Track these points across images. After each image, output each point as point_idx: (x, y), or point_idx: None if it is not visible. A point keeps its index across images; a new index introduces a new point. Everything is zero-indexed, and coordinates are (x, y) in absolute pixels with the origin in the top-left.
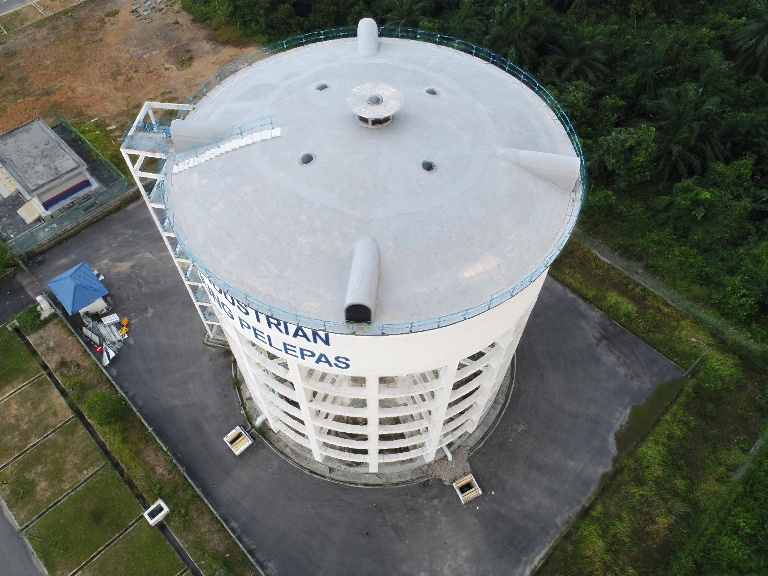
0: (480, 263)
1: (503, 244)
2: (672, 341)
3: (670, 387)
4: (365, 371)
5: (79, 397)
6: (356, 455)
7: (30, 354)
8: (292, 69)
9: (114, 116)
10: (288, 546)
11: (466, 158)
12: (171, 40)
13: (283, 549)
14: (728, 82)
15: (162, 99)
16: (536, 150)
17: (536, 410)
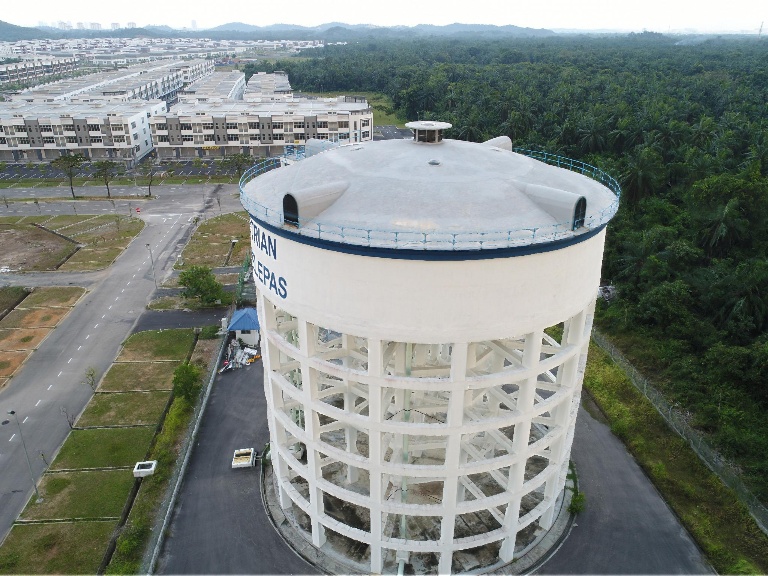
0: (418, 222)
1: (452, 220)
2: None
3: None
4: (296, 306)
5: None
6: (304, 500)
7: (189, 348)
8: None
9: None
10: (194, 553)
11: (473, 171)
12: None
13: (189, 553)
14: None
15: None
16: None
17: None
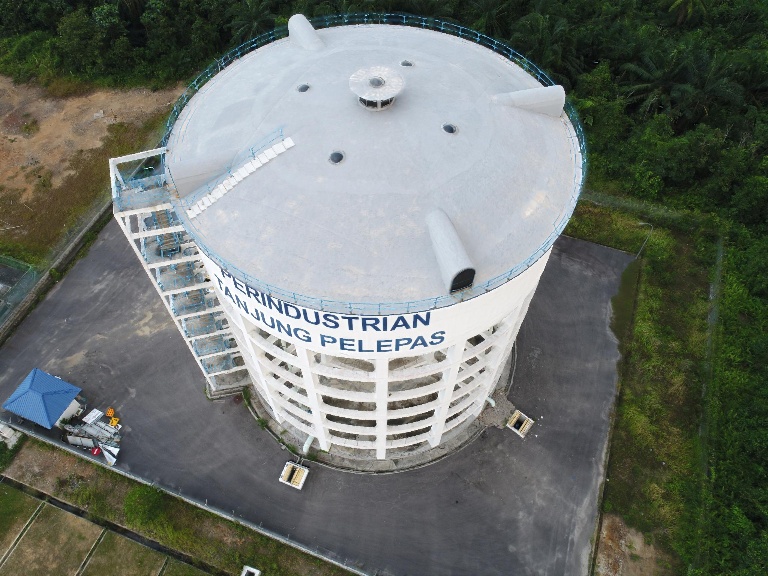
0: (532, 200)
1: (540, 177)
2: (614, 234)
3: (631, 272)
4: (457, 338)
5: (100, 509)
6: (421, 435)
7: (16, 490)
8: (254, 82)
9: None
10: (393, 548)
11: (474, 113)
12: (0, 109)
13: (389, 553)
14: (557, 5)
15: (25, 173)
16: (516, 90)
17: (540, 333)
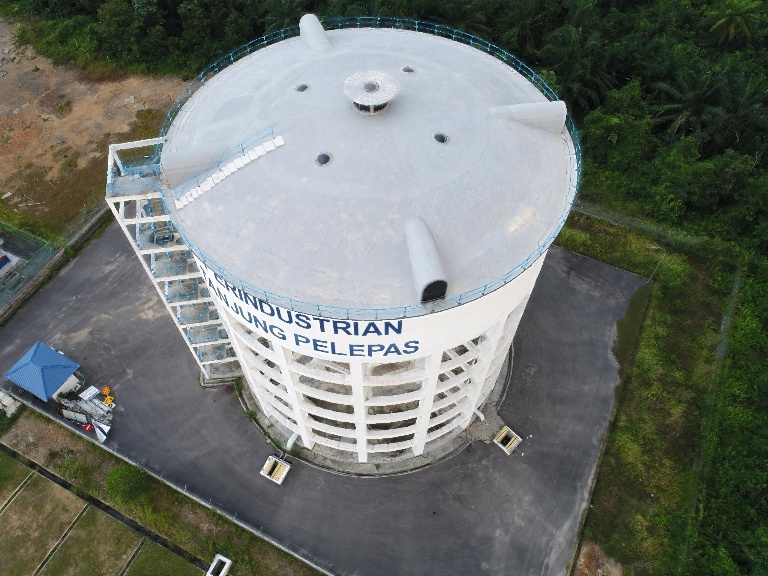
0: (518, 216)
1: (530, 193)
2: (627, 256)
3: (640, 296)
4: (432, 349)
5: (86, 483)
6: (403, 442)
7: (10, 457)
8: (257, 78)
9: (5, 182)
10: (364, 552)
11: (469, 123)
12: (38, 89)
13: (361, 557)
14: (594, 19)
15: (53, 152)
16: (518, 103)
17: (539, 351)
